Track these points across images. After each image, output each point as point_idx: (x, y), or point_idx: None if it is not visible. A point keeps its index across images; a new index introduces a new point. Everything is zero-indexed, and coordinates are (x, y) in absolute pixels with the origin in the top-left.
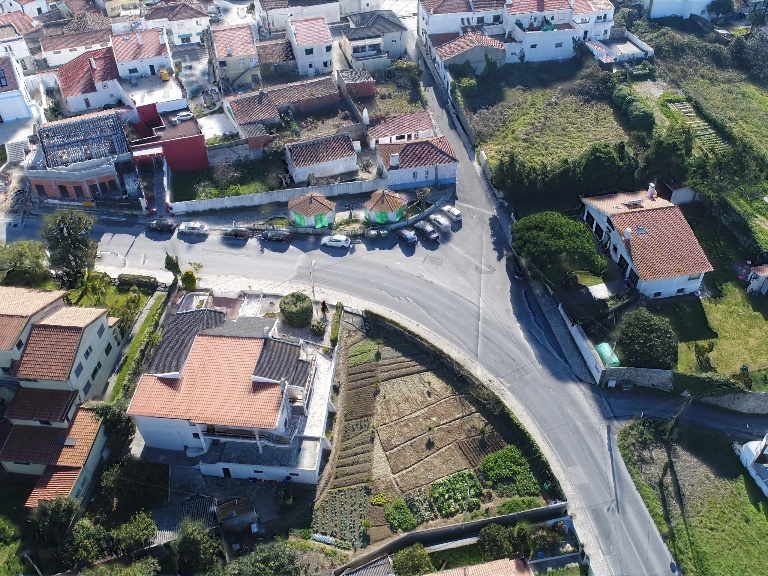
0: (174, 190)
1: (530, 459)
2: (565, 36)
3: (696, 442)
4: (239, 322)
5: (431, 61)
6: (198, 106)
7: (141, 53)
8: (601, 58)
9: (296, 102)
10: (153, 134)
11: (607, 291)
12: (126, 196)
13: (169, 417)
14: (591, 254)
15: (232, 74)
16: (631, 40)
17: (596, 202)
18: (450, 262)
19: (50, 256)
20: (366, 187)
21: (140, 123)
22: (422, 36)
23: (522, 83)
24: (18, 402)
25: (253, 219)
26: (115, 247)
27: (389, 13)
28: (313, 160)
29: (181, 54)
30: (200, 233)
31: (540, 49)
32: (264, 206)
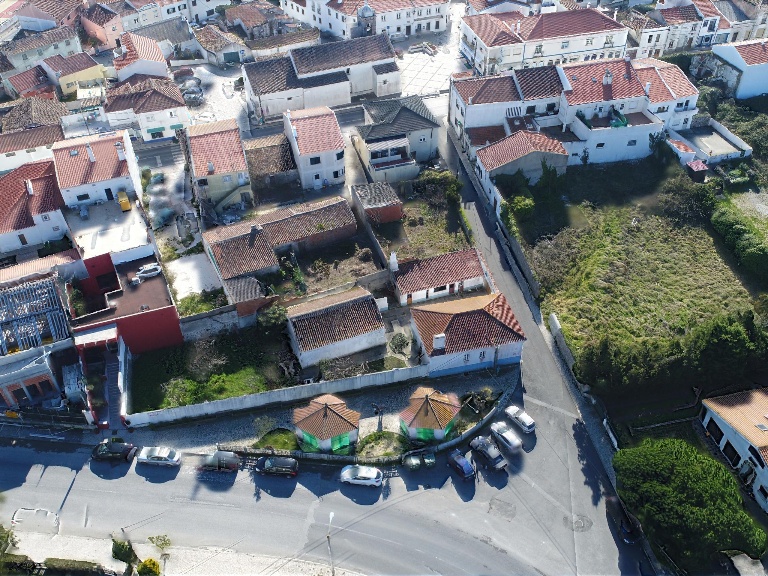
0: (134, 385)
1: None
2: (640, 132)
3: None
4: None
5: (469, 162)
6: (170, 241)
7: (93, 174)
8: (690, 163)
9: (300, 239)
10: (105, 303)
11: (762, 570)
12: (65, 402)
13: None
14: (748, 531)
15: (215, 194)
16: (717, 130)
17: (726, 411)
18: (526, 510)
19: None
20: (399, 376)
21: (89, 279)
22: (455, 126)
23: (589, 196)
24: None
25: (244, 433)
26: (45, 493)
27: (414, 101)
28: (326, 338)
29: (151, 155)
30: (168, 464)
31: (608, 148)
32: (259, 409)
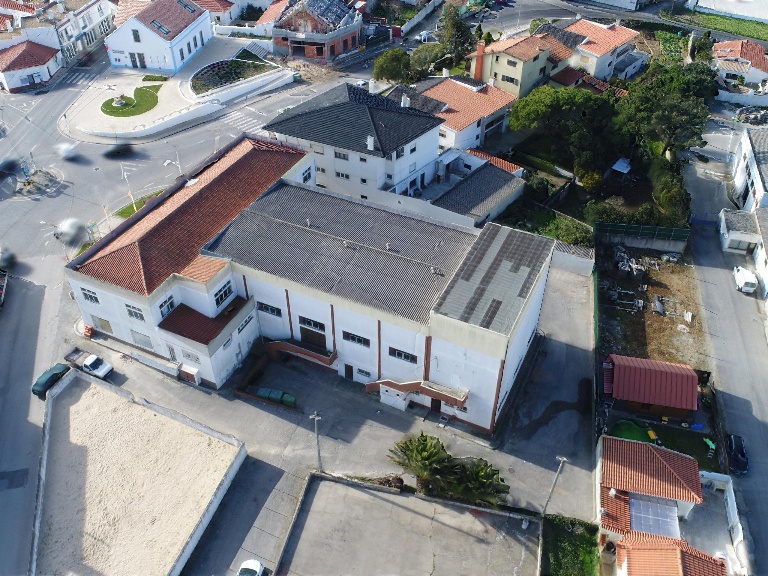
0: None
1: (665, 31)
2: None
3: (676, 11)
4: (557, 24)
5: None
6: None
7: None
8: None
9: None
10: None
11: None
12: None
13: (612, 49)
14: None
15: None
16: None
17: None
18: (529, 3)
19: (459, 36)
20: None
21: None
22: None
23: None
24: (561, 80)
25: (434, 24)
26: None
27: None
28: None
29: None
30: None
31: None
32: (426, 18)
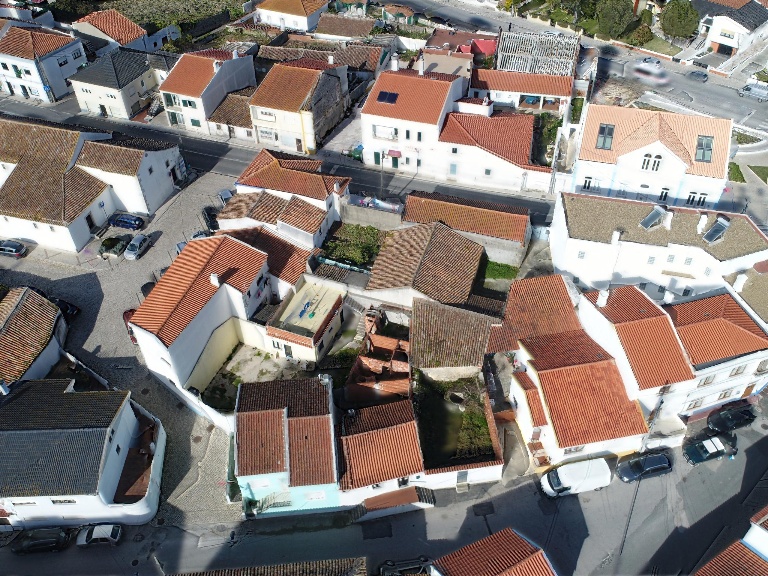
0: None
1: None
2: None
3: None
4: None
5: None
6: None
7: None
8: (39, 2)
9: None
10: None
11: None
12: None
13: None
14: None
15: None
16: None
17: None
18: None
19: None
20: None
21: None
22: None
23: None
24: None
25: None
26: None
27: None
28: None
29: None
30: None
31: None
32: None
